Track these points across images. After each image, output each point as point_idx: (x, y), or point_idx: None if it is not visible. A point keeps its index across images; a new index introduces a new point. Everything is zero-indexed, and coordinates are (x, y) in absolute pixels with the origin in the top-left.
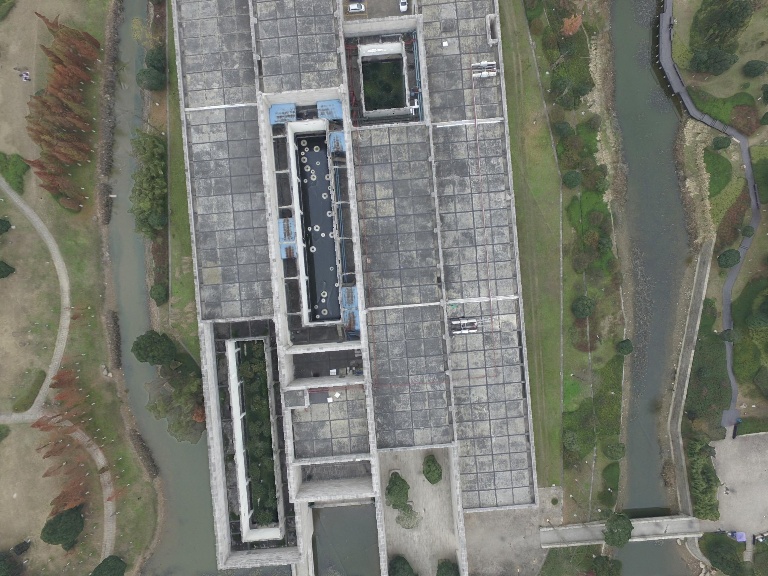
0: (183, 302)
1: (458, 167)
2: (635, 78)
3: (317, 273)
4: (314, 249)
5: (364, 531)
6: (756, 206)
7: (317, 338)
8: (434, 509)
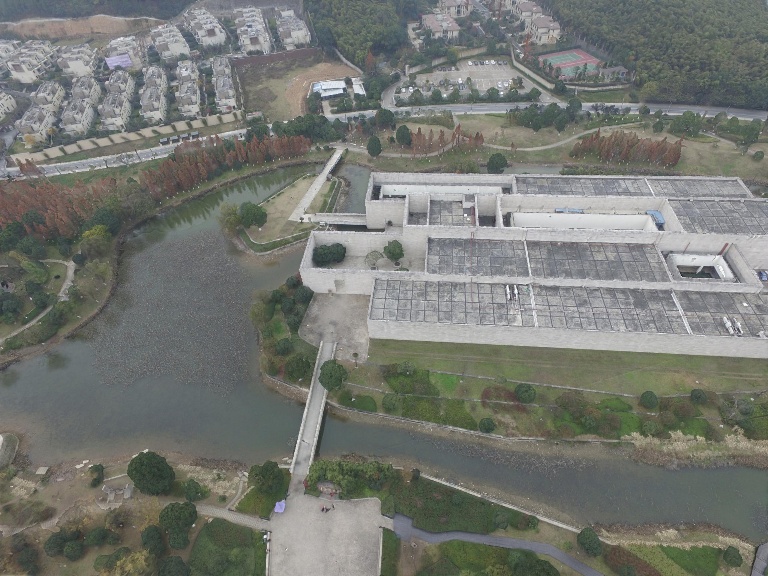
0: None
1: (641, 303)
2: None
3: None
4: None
5: None
6: None
7: None
8: None
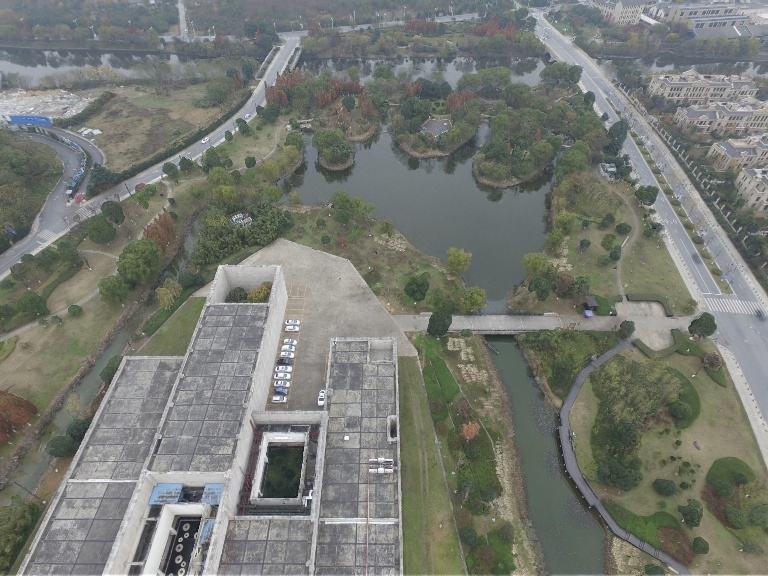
0: None
1: None
2: (546, 485)
3: None
4: None
5: None
6: None
7: None
8: None
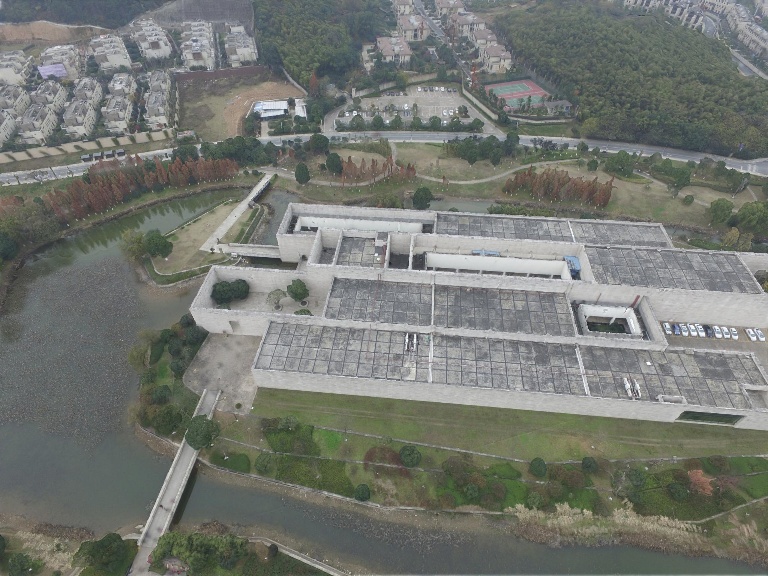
0: None
1: (543, 358)
2: None
3: None
4: None
5: None
6: None
7: (415, 268)
8: None
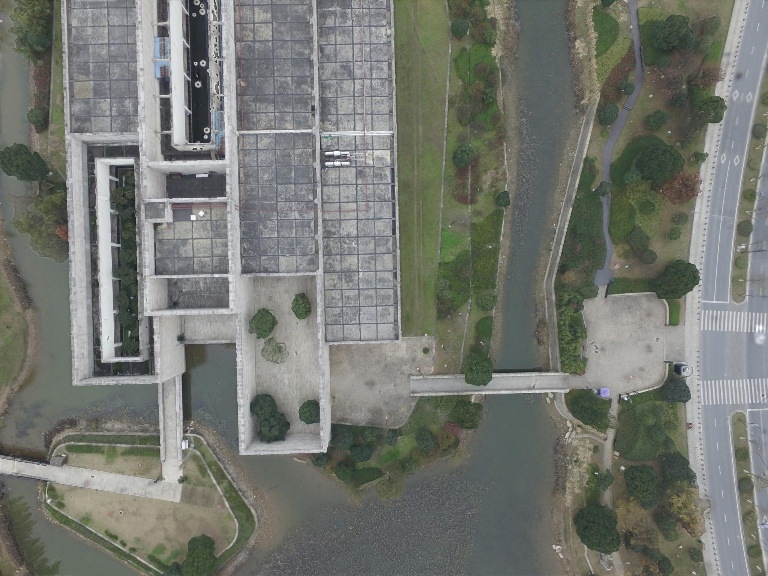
0: (63, 130)
1: None
2: None
3: (210, 121)
4: (199, 84)
5: None
6: (641, 68)
7: None
8: (306, 352)
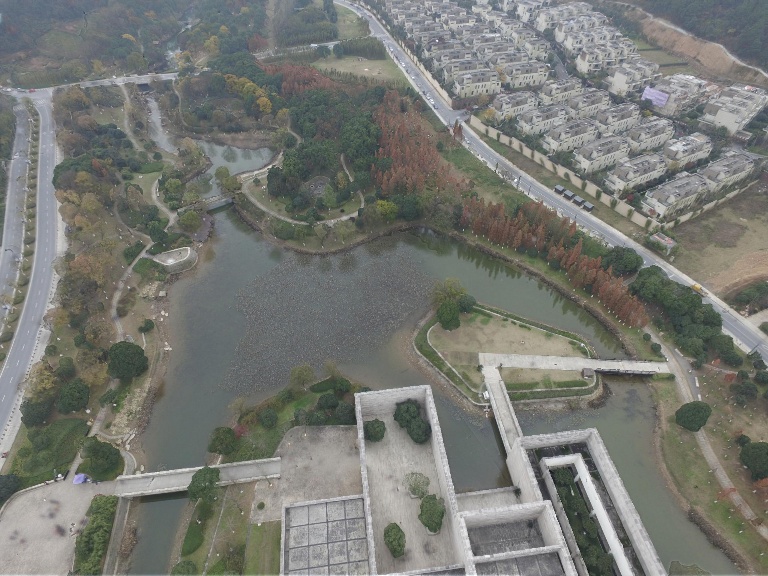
0: None
1: None
2: None
3: None
4: None
5: (456, 464)
6: None
7: None
8: (388, 491)
